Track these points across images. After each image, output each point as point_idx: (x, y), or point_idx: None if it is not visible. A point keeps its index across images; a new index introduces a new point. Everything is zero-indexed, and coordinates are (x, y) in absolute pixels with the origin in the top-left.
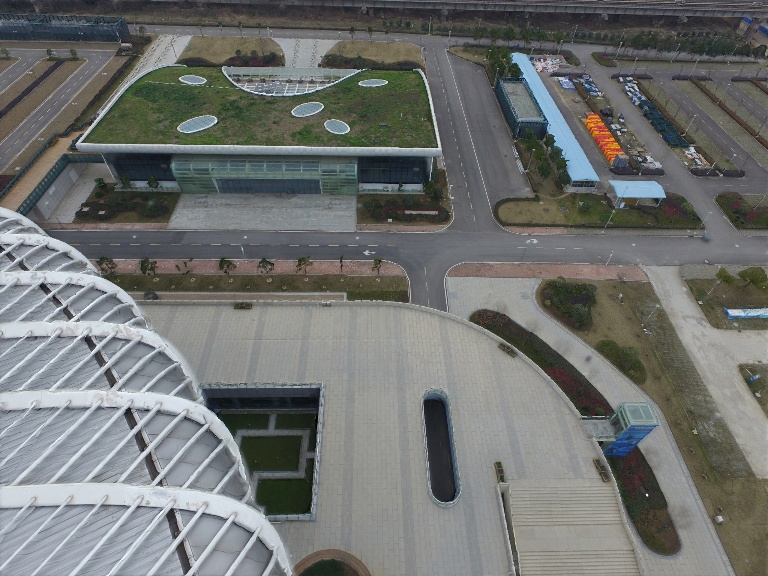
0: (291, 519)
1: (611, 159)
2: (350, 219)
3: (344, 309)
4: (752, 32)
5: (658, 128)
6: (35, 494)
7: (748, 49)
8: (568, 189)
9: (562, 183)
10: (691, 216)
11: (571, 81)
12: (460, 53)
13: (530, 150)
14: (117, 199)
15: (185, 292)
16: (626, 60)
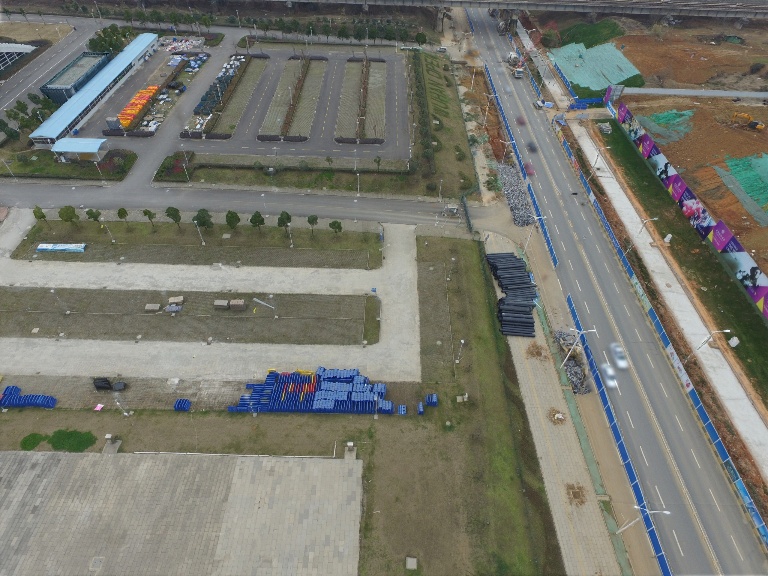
0: None
1: None
2: None
3: None
4: (438, 20)
5: None
6: None
7: (388, 33)
8: (36, 146)
9: None
10: (118, 169)
11: None
12: None
13: None
14: None
15: None
16: (267, 42)
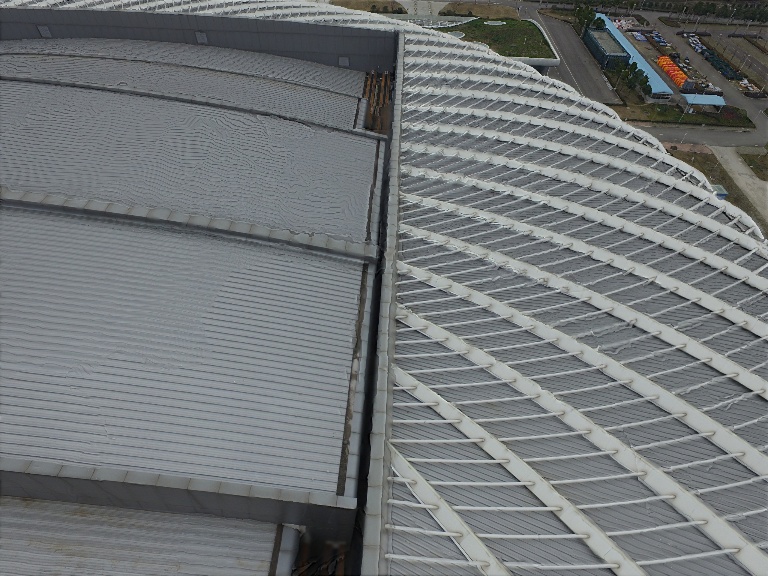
0: None
1: (681, 84)
2: None
3: None
4: None
5: (717, 67)
6: (508, 69)
7: None
8: (648, 101)
9: (645, 93)
10: (745, 119)
11: (643, 35)
12: (549, 14)
13: (618, 73)
14: None
15: None
16: (688, 23)
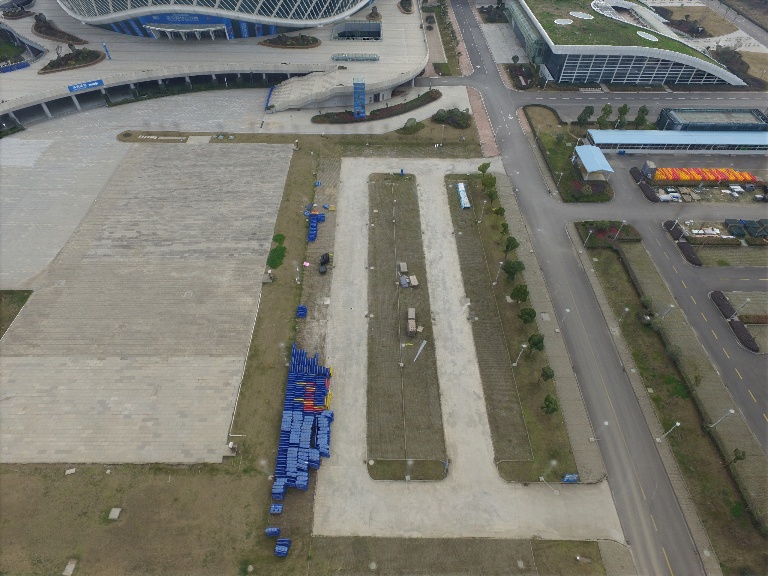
0: None
1: None
2: (506, 62)
3: (424, 44)
4: None
5: None
6: None
7: None
8: None
9: None
10: (578, 194)
11: None
12: None
13: None
14: (491, 7)
15: (440, 32)
16: None
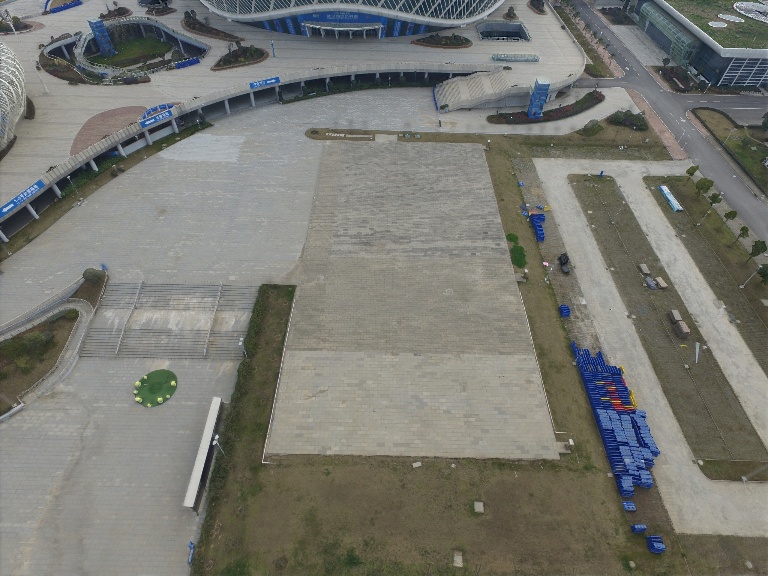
0: (480, 37)
1: None
2: (653, 64)
3: None
4: None
5: None
6: None
7: None
8: None
9: None
10: None
11: None
12: None
13: None
14: None
15: None
16: None
